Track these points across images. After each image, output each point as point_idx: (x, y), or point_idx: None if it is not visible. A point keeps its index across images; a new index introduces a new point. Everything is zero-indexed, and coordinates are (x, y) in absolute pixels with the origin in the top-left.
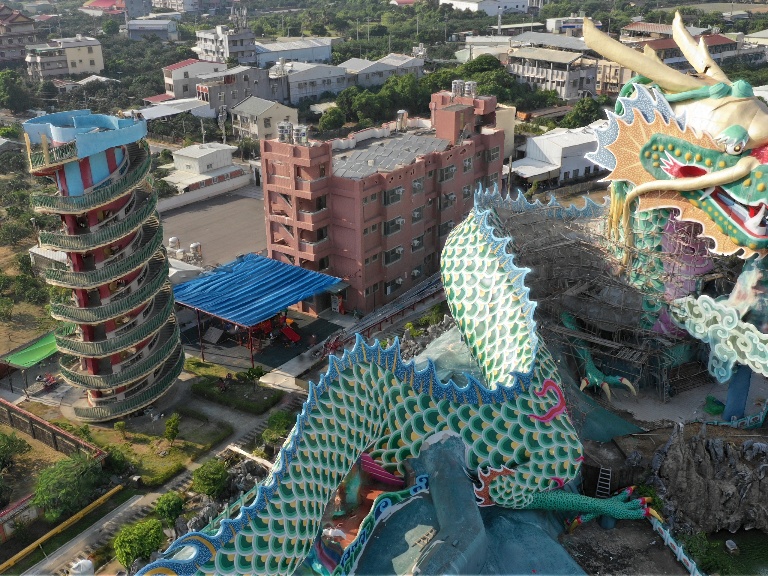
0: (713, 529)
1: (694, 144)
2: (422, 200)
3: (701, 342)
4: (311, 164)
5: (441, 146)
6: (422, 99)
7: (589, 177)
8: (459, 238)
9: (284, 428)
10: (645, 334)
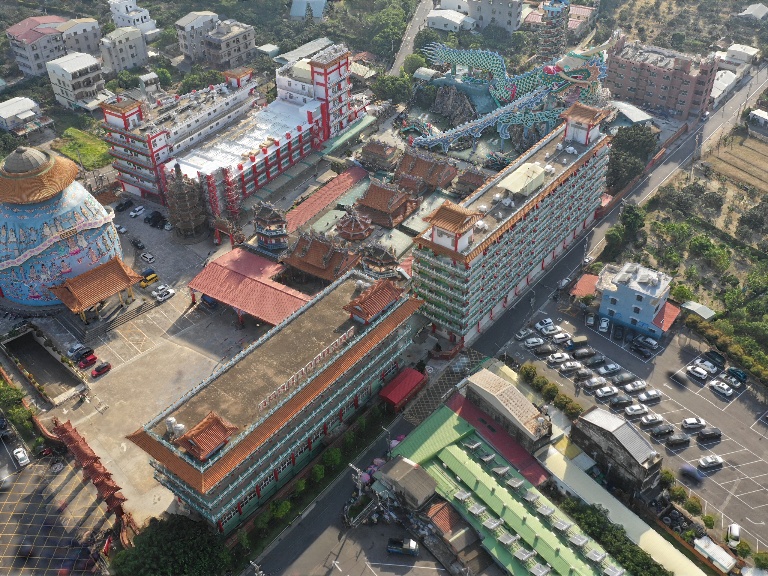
0: None
1: None
2: (637, 76)
3: None
4: None
5: None
6: None
7: None
8: None
9: None
10: None
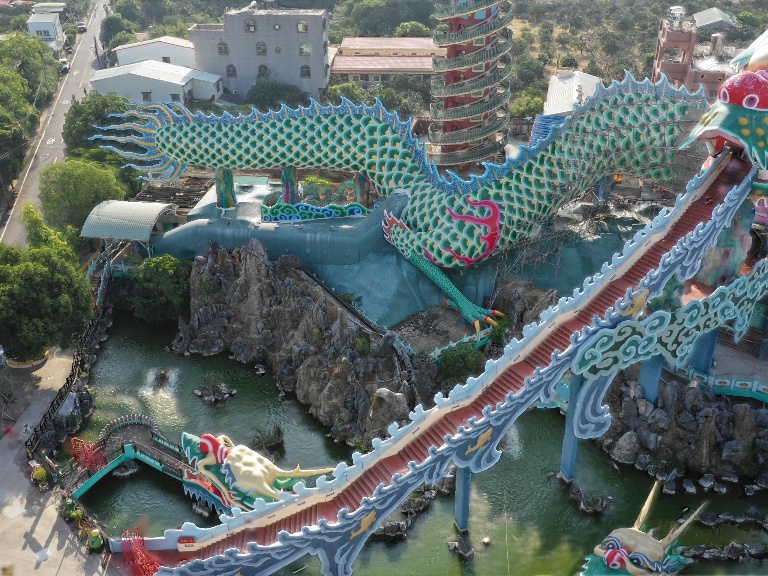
0: None
1: None
2: None
3: (762, 307)
4: (665, 45)
5: None
6: None
7: None
8: None
9: None
10: None
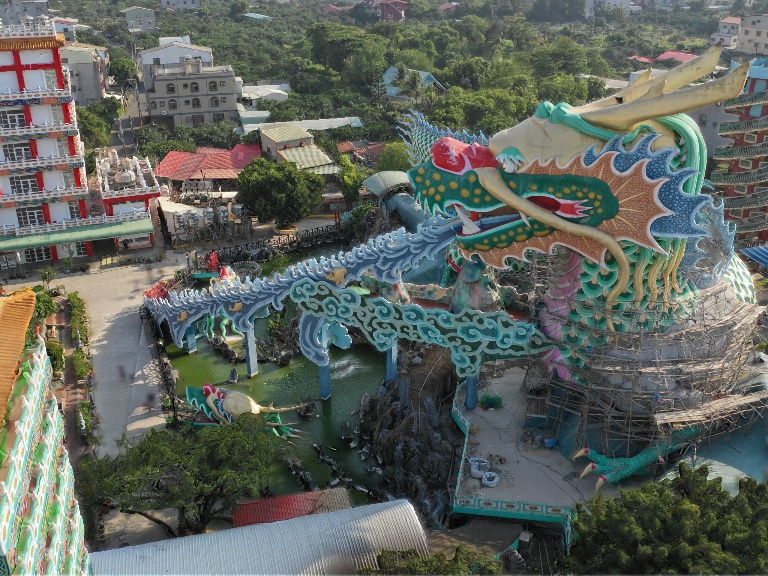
0: None
1: None
2: None
3: None
4: None
5: None
6: None
7: None
8: None
9: None
10: None
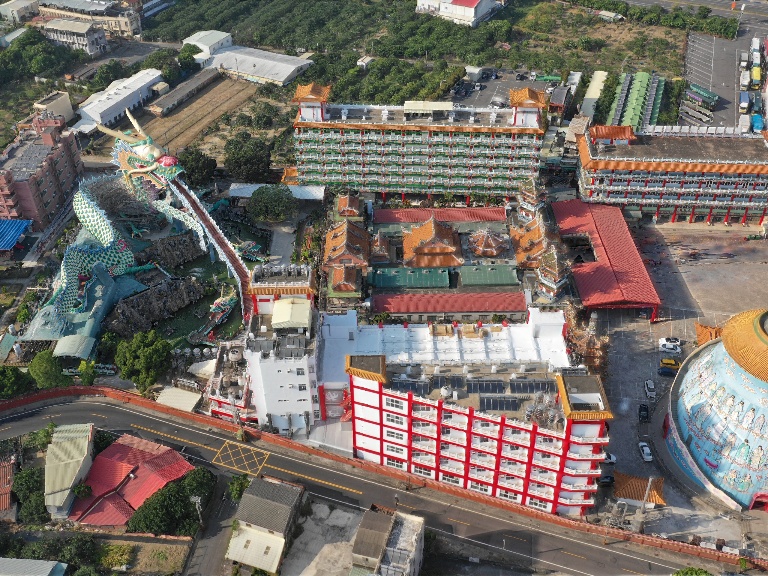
0: (177, 265)
1: (141, 159)
2: (51, 177)
3: None
4: (6, 181)
5: (49, 149)
6: (0, 74)
7: (118, 121)
8: (79, 203)
9: (43, 277)
10: (147, 214)
